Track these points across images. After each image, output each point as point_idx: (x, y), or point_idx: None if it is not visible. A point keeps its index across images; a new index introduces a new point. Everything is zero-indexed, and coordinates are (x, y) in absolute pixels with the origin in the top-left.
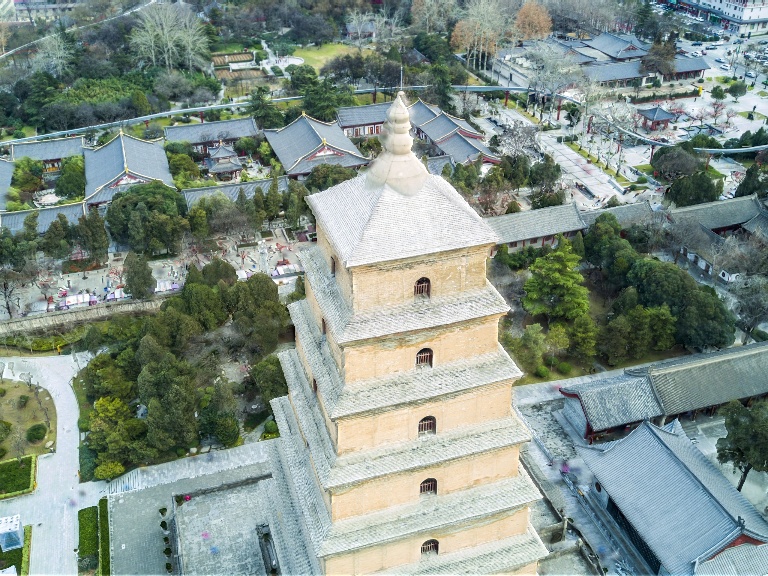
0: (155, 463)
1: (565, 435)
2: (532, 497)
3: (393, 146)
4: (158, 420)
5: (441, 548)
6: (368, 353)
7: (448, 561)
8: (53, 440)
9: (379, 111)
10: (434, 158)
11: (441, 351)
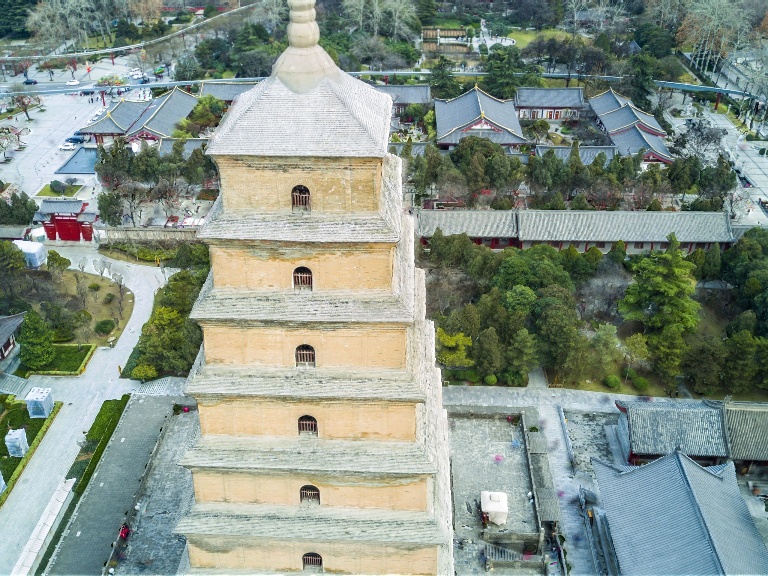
0: (186, 376)
1: (607, 452)
2: (425, 469)
3: (289, 36)
4: (192, 334)
5: (323, 498)
6: (237, 258)
7: (330, 515)
8: (117, 337)
9: (563, 96)
10: (595, 147)
11: (321, 274)
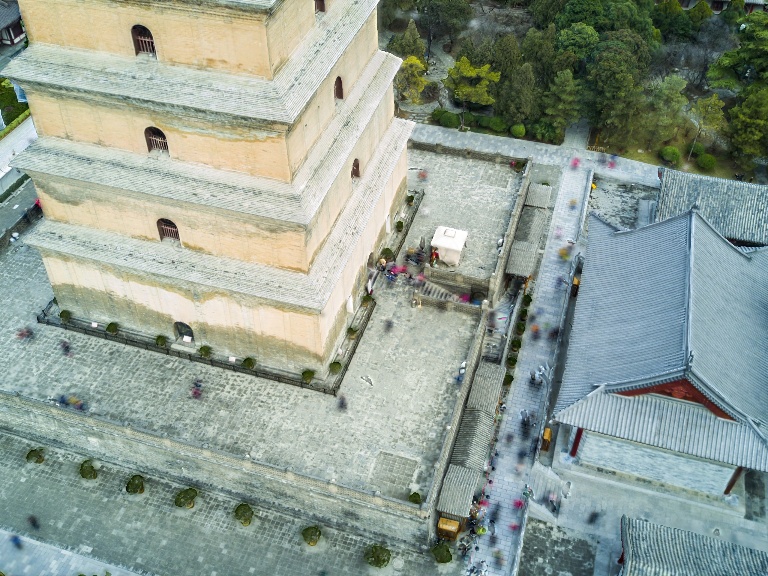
0: None
1: (631, 227)
2: (277, 115)
3: None
4: None
5: (172, 148)
6: None
7: (180, 171)
8: None
9: None
10: None
11: None
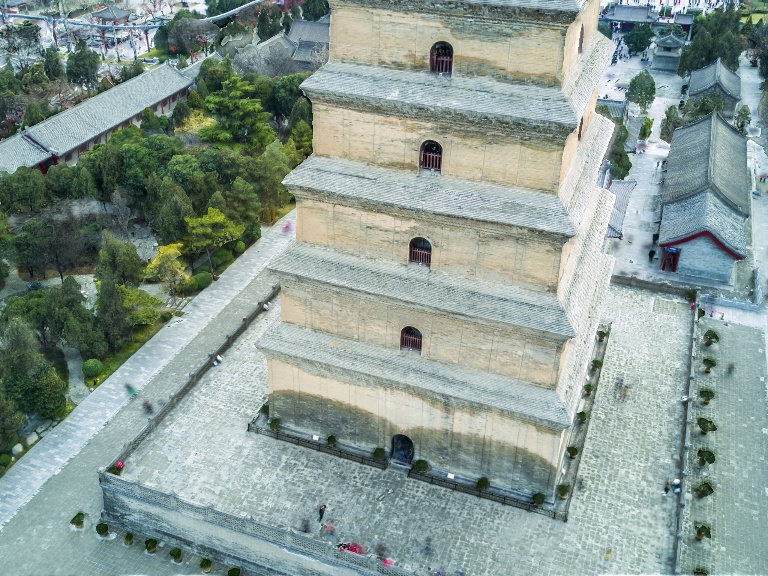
0: None
1: None
2: (612, 126)
3: None
4: None
5: None
6: None
7: (586, 229)
8: None
9: None
10: None
11: None
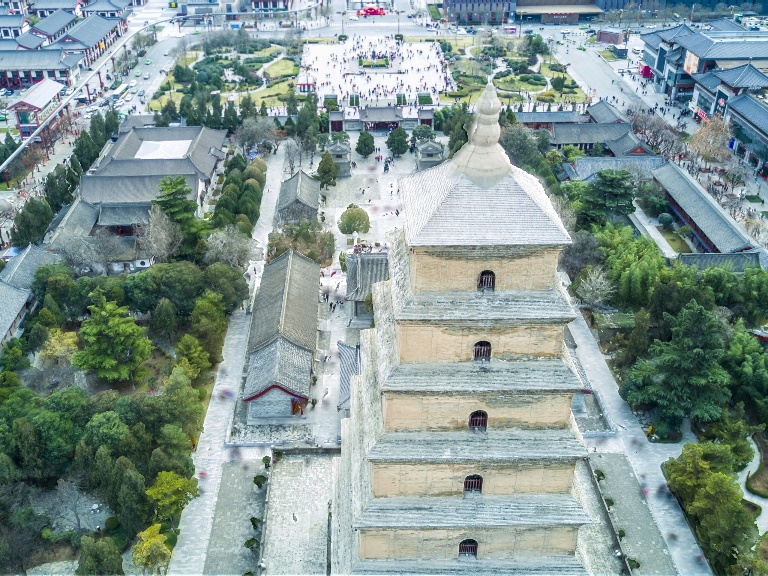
0: None
1: (281, 426)
2: None
3: None
4: None
5: None
6: None
7: None
8: None
9: None
10: None
11: None
